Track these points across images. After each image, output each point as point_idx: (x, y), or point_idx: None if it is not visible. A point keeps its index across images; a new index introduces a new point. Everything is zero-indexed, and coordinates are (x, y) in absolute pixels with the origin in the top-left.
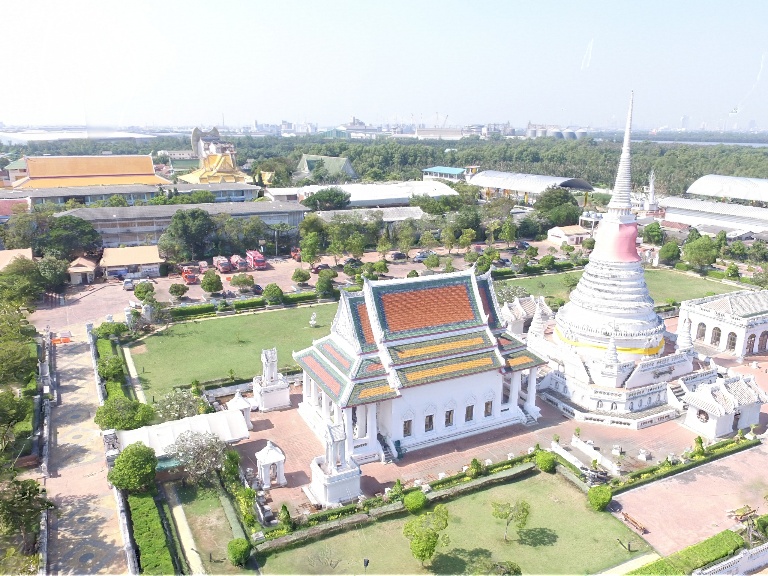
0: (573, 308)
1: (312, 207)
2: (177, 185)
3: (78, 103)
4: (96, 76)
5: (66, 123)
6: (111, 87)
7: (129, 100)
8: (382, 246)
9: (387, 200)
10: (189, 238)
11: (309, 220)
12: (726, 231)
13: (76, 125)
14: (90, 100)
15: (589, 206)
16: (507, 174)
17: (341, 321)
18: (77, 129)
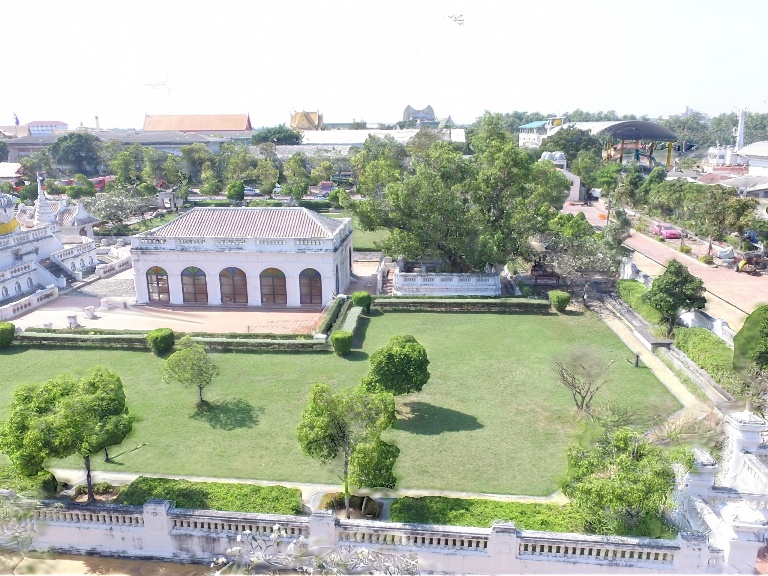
0: None
1: (252, 145)
2: (209, 133)
3: (160, 61)
4: (179, 36)
5: (148, 79)
6: (193, 46)
7: (210, 58)
8: (203, 173)
9: (362, 145)
10: (61, 159)
11: (183, 149)
12: (757, 182)
13: (157, 81)
14: (171, 58)
15: (583, 149)
16: (580, 123)
17: None
18: (159, 85)
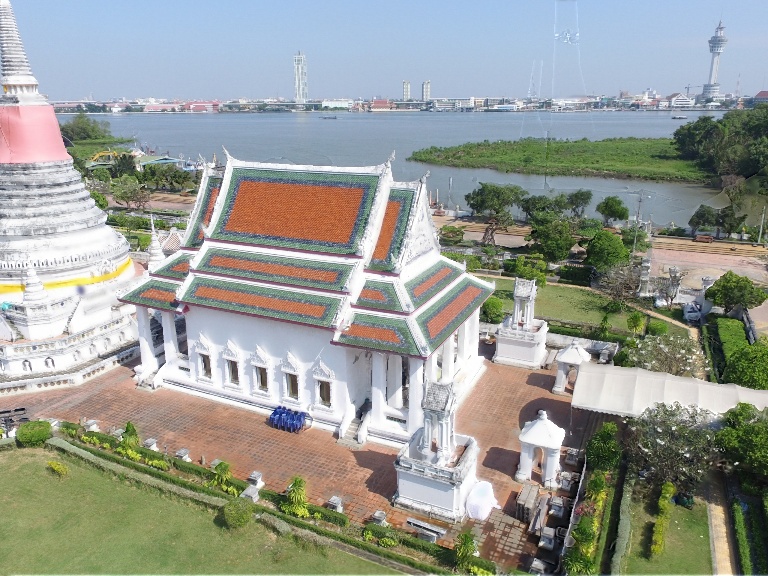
0: (70, 239)
1: None
2: None
3: None
4: None
5: None
6: None
7: None
8: None
9: None
10: None
11: None
12: None
13: None
14: None
15: None
16: None
17: (416, 234)
18: None
